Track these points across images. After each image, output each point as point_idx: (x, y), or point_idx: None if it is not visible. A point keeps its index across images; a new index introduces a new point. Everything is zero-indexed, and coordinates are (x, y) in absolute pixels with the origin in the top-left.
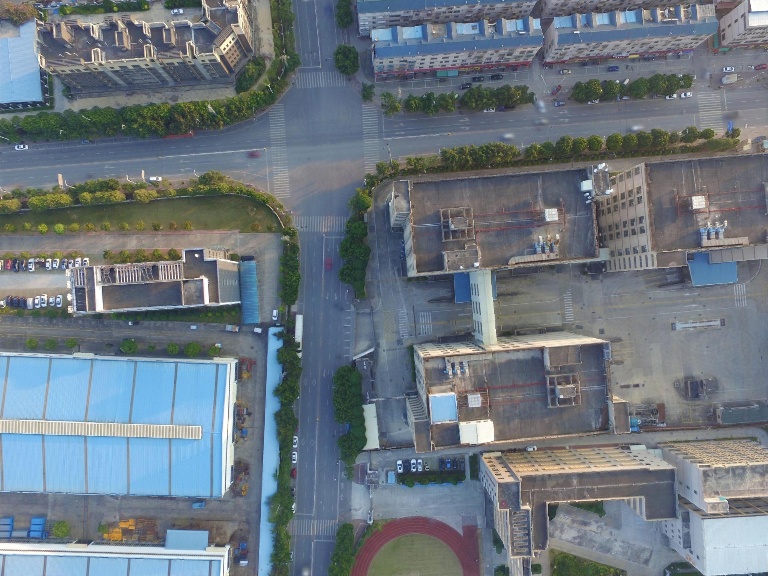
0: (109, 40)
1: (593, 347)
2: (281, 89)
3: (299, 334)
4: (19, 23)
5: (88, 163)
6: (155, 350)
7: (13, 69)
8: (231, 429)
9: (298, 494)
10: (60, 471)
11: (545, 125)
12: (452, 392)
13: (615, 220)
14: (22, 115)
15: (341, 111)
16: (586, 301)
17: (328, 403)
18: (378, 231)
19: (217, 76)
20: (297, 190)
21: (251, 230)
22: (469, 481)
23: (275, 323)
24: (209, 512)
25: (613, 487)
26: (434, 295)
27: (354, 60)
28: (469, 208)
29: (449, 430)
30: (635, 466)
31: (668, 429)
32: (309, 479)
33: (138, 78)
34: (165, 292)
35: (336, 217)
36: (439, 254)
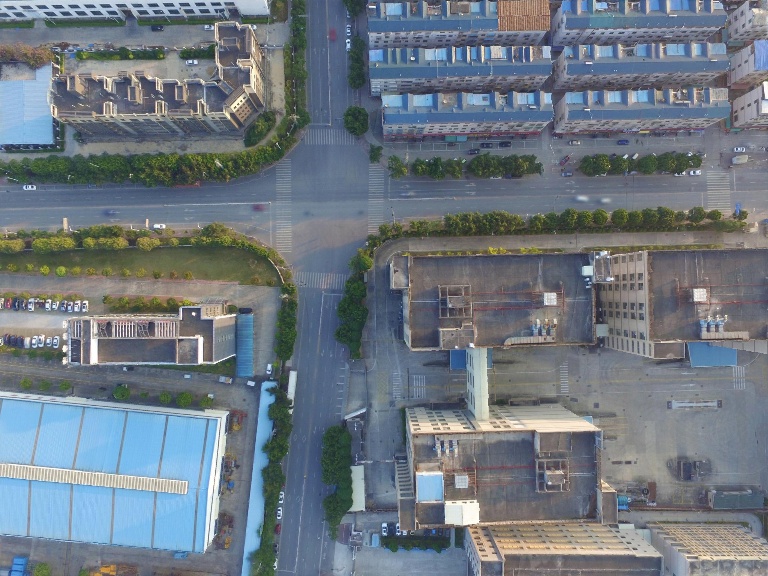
0: (122, 93)
1: (585, 433)
2: (289, 146)
3: (292, 391)
4: (35, 66)
5: (94, 207)
6: (148, 397)
7: (26, 111)
8: (218, 482)
9: (281, 550)
10: (45, 517)
11: (551, 195)
12: (440, 471)
13: (615, 299)
14: (32, 156)
15: (348, 169)
16: (582, 374)
17: (317, 460)
18: (377, 291)
19: (227, 130)
20: (299, 245)
21: (251, 282)
22: (453, 548)
23: (269, 377)
24: (191, 562)
25: (598, 571)
26: (429, 358)
27: (363, 122)
28: (468, 286)
29: (434, 508)
30: (621, 551)
31: (658, 509)
32: (293, 536)
33: (148, 129)
34: (160, 348)
35: (336, 274)
36: (435, 330)
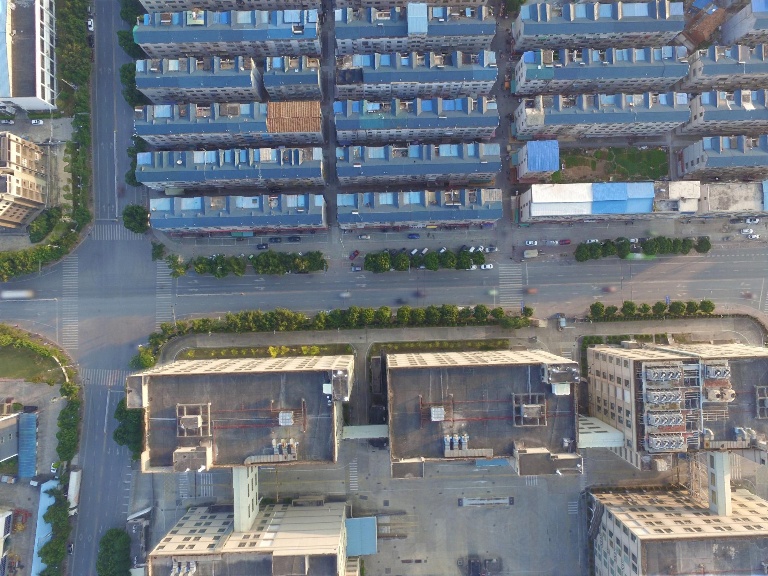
0: None
1: None
2: (70, 244)
3: (72, 492)
4: None
5: None
6: None
7: None
8: None
9: None
10: None
11: (341, 289)
12: None
13: None
14: None
15: (136, 264)
16: (372, 471)
17: None
18: None
19: (4, 229)
20: (86, 342)
21: None
22: None
23: (54, 476)
24: None
25: None
26: None
27: (142, 221)
28: (206, 405)
29: None
30: None
31: None
32: None
33: None
34: None
35: (123, 371)
36: (175, 449)
